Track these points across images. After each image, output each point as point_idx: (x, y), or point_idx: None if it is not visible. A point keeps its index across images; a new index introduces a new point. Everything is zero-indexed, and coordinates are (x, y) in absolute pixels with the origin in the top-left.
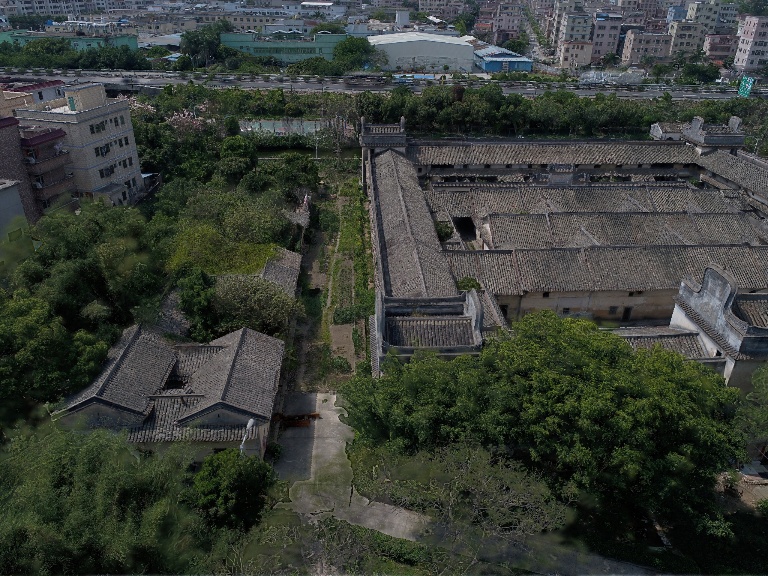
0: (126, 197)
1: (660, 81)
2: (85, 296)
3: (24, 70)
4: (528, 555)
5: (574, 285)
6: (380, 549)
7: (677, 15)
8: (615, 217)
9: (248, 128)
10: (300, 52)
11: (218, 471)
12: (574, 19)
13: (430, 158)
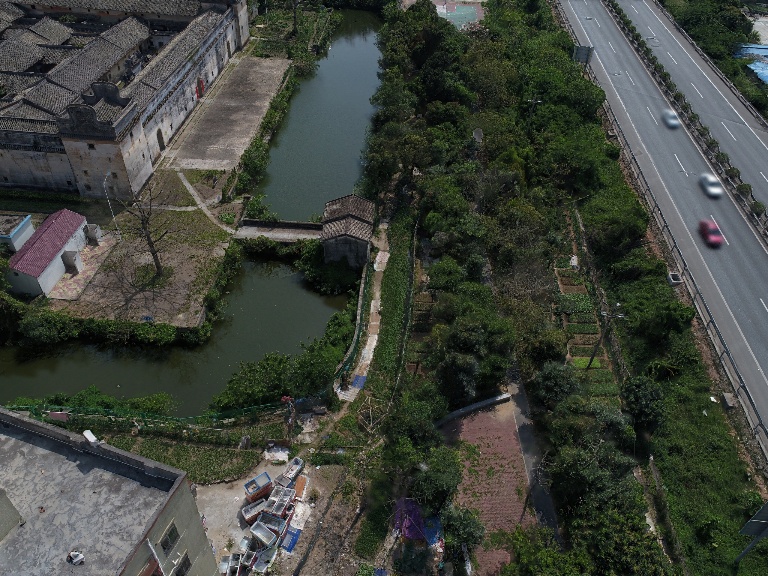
0: None
1: None
2: None
3: None
4: None
5: None
6: None
7: None
8: None
9: (446, 10)
10: None
11: None
12: None
13: None
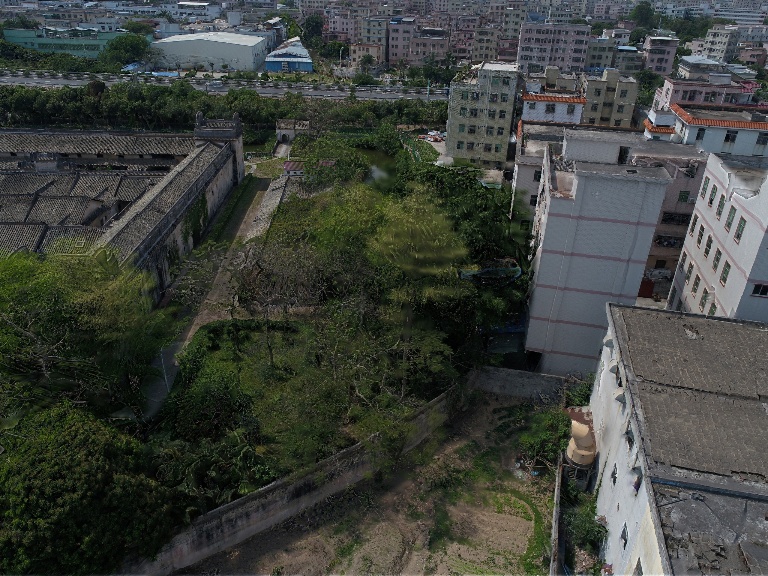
0: None
1: (397, 83)
2: None
3: None
4: None
5: None
6: None
7: None
8: None
9: None
10: (84, 49)
11: None
12: (369, 22)
13: None
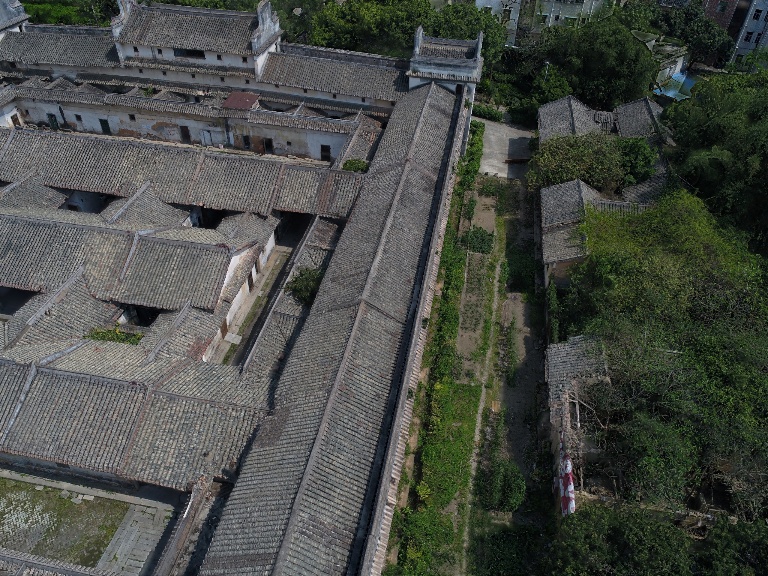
0: None
1: None
2: None
3: None
4: None
5: None
6: None
7: None
8: None
9: None
10: None
11: None
12: None
13: None
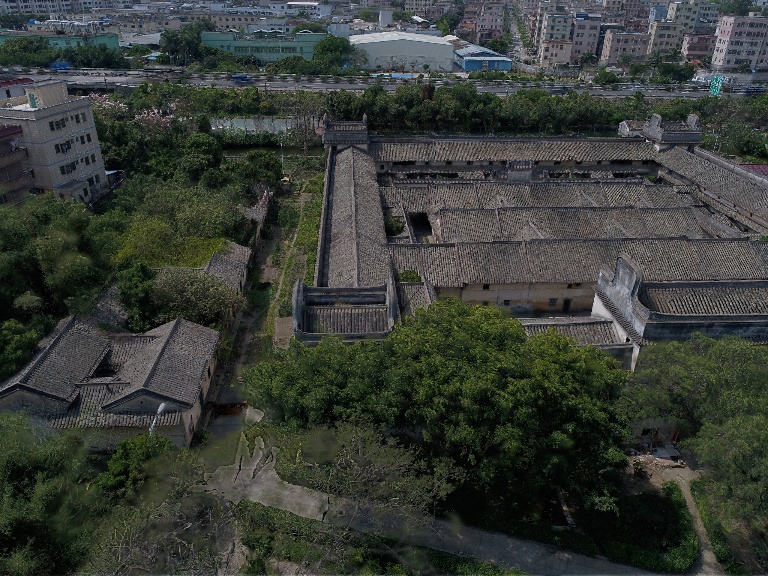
0: (88, 193)
1: (635, 80)
2: (19, 287)
3: (0, 69)
4: (435, 534)
5: (513, 277)
6: (290, 529)
7: (658, 15)
8: (563, 212)
9: (221, 126)
10: (281, 51)
11: (131, 454)
12: (554, 19)
13: (392, 155)
